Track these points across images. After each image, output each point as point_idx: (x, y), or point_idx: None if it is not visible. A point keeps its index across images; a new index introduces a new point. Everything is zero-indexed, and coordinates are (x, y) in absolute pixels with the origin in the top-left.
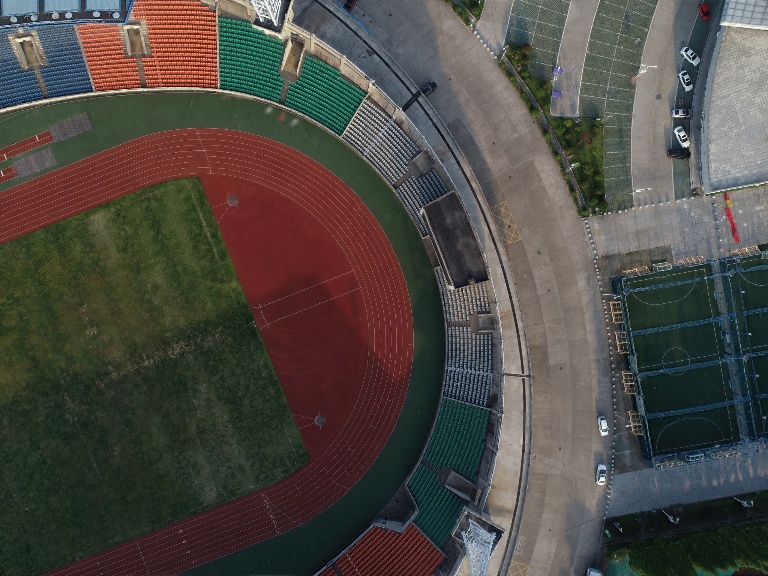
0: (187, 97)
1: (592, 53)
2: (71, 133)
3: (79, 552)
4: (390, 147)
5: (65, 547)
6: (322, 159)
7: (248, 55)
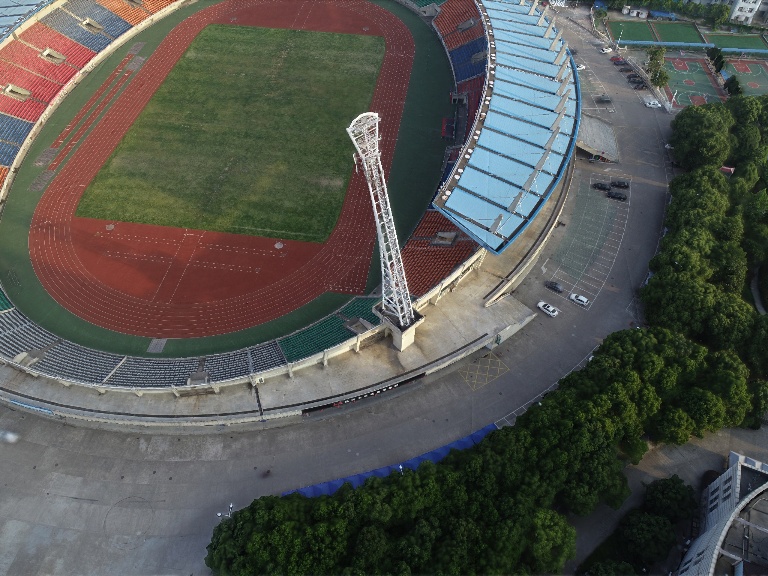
0: (172, 15)
1: None
2: None
3: None
4: None
5: None
6: None
7: None
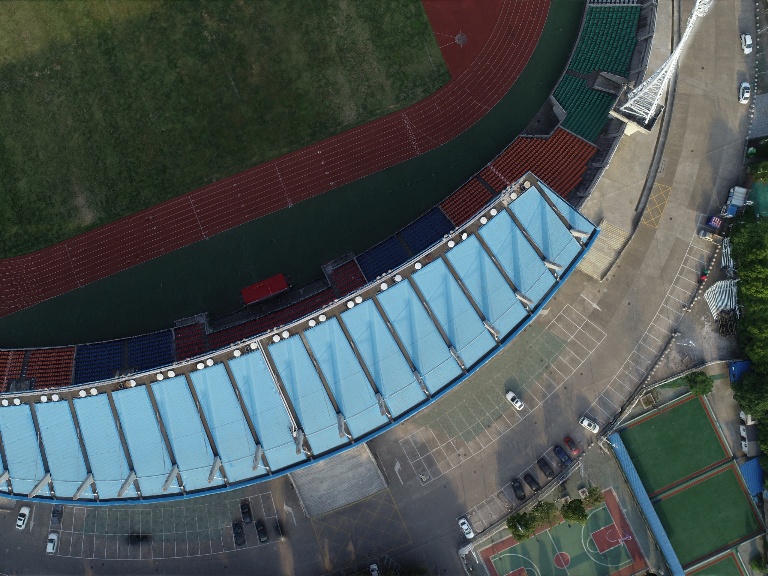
0: None
1: None
2: None
3: (216, 173)
4: None
5: (202, 168)
6: None
7: None
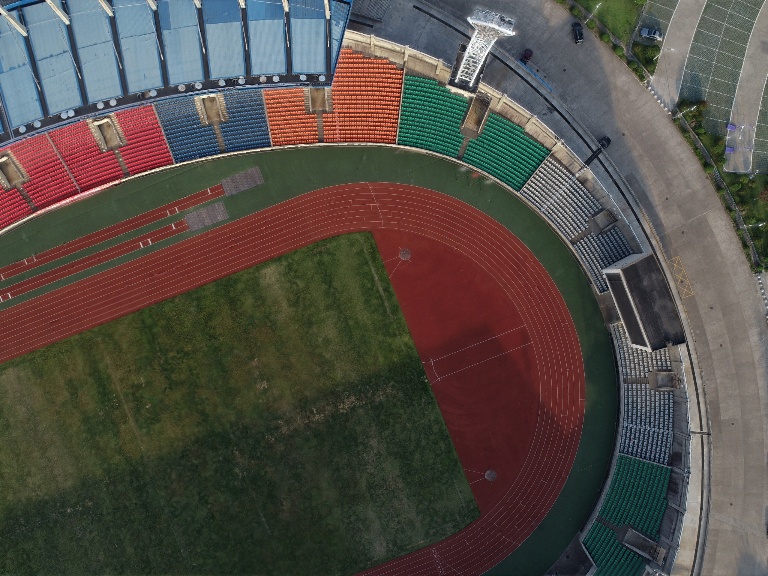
0: (360, 151)
1: (765, 109)
2: (243, 186)
3: None
4: (570, 204)
5: None
6: (495, 214)
7: (430, 112)
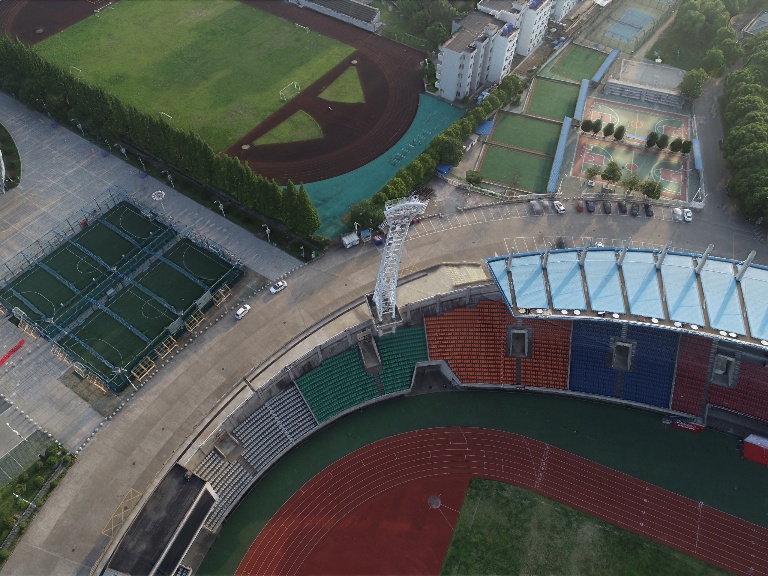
0: None
1: None
2: None
3: None
4: None
5: None
6: None
7: None
